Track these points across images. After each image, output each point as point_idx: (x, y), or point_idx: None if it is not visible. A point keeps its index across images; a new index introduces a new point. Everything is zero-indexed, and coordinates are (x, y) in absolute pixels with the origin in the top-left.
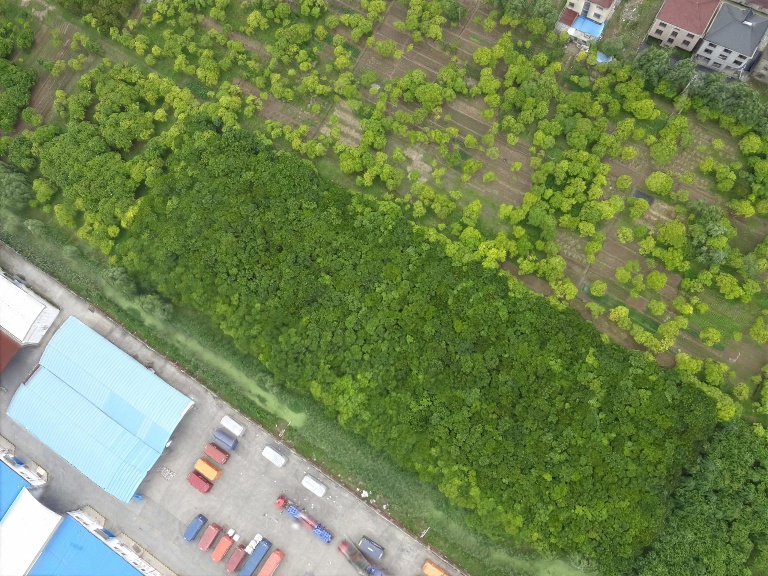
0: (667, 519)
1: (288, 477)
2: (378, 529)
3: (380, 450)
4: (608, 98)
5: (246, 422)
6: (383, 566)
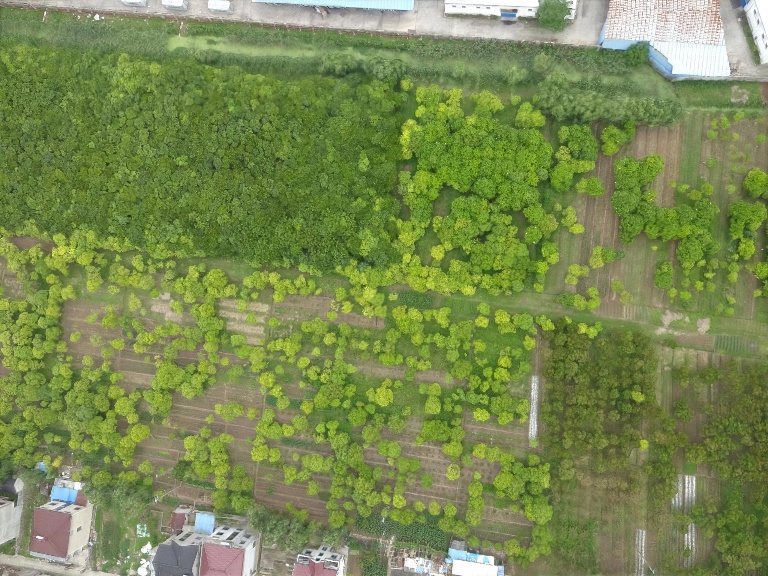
0: None
1: None
2: None
3: None
4: (20, 426)
5: None
6: None
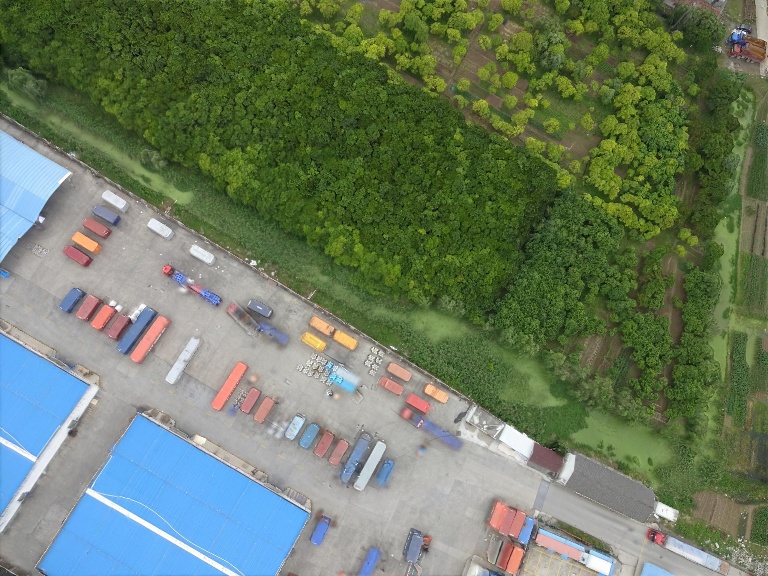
0: (519, 267)
1: (175, 250)
2: (266, 294)
3: (269, 220)
4: None
5: (129, 200)
6: (271, 326)
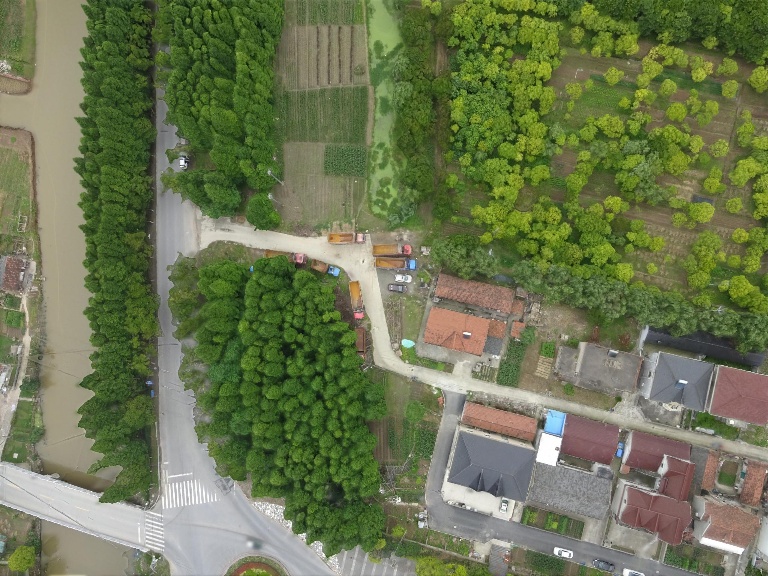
0: None
1: None
2: None
3: None
4: None
5: None
6: None
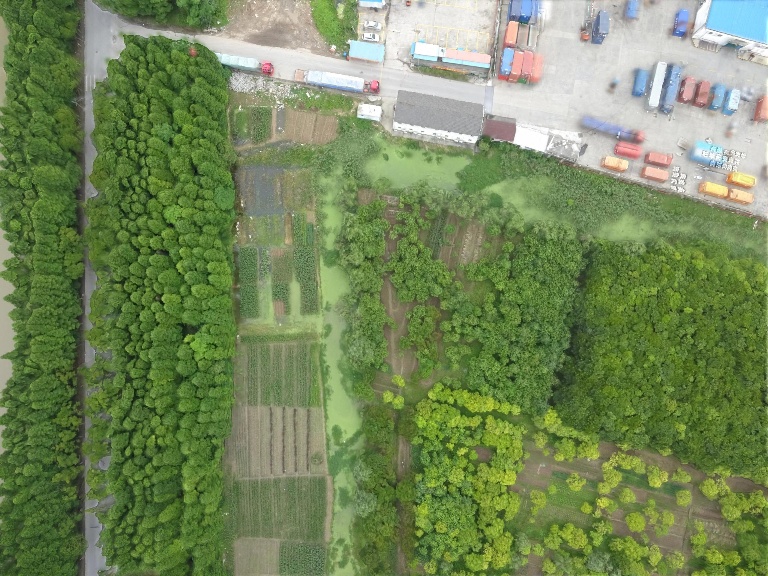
0: (574, 308)
1: None
2: None
3: None
4: None
5: None
6: None
